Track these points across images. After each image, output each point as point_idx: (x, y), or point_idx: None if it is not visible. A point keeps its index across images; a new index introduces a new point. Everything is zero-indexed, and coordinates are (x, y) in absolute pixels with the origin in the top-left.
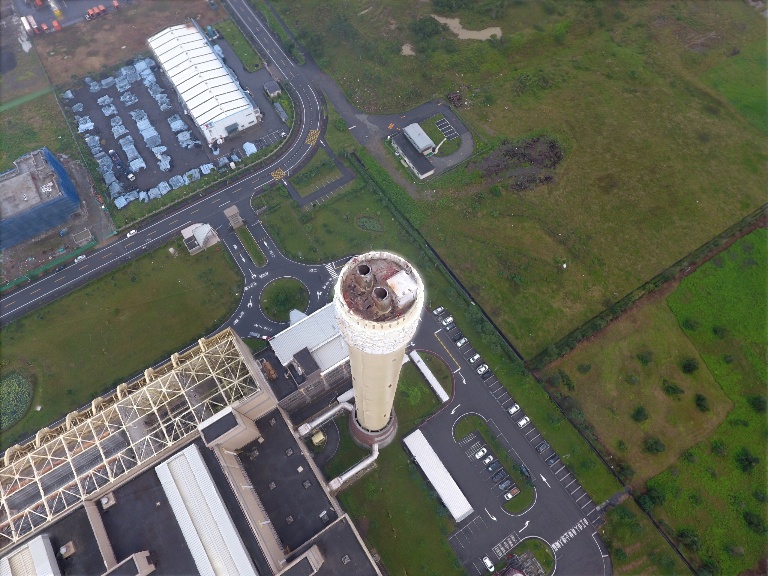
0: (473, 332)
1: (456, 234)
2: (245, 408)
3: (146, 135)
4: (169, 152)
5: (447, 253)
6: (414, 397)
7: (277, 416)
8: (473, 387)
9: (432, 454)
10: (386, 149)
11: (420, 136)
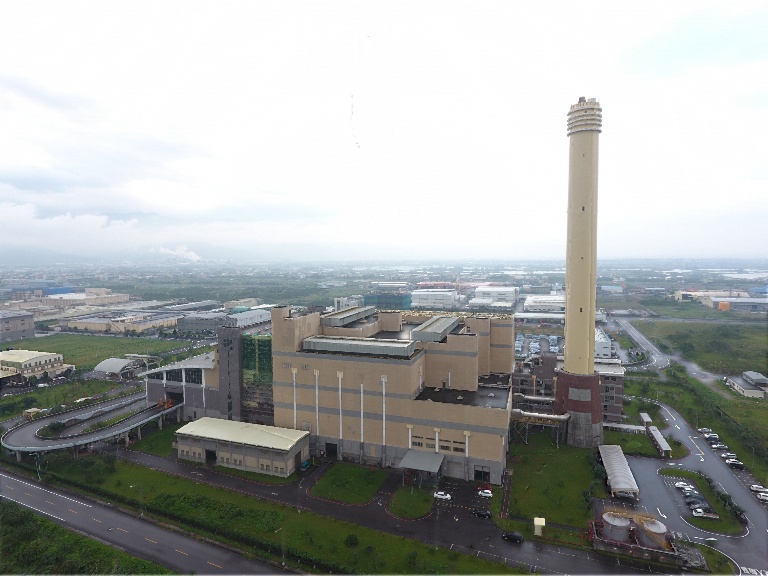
0: (740, 448)
1: (765, 417)
2: (495, 335)
3: (532, 345)
4: (540, 351)
5: (744, 419)
6: (632, 444)
7: (507, 377)
8: (711, 465)
9: (621, 457)
10: (718, 383)
11: (758, 375)
